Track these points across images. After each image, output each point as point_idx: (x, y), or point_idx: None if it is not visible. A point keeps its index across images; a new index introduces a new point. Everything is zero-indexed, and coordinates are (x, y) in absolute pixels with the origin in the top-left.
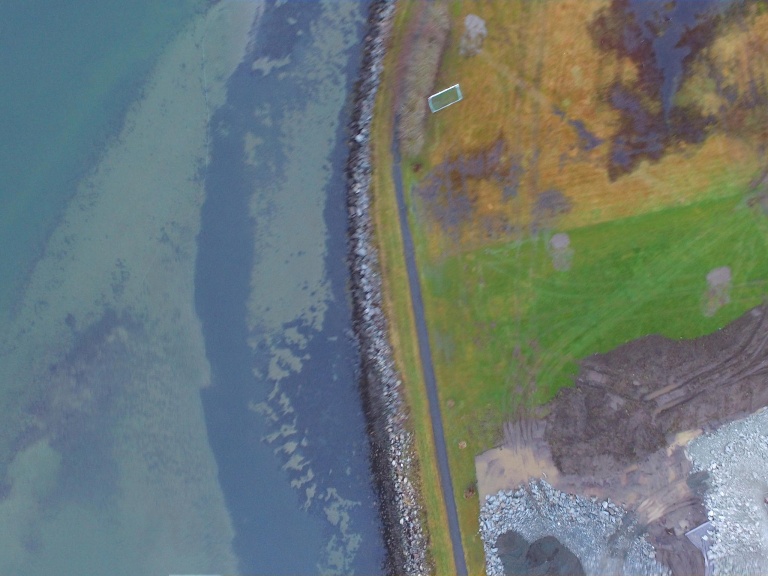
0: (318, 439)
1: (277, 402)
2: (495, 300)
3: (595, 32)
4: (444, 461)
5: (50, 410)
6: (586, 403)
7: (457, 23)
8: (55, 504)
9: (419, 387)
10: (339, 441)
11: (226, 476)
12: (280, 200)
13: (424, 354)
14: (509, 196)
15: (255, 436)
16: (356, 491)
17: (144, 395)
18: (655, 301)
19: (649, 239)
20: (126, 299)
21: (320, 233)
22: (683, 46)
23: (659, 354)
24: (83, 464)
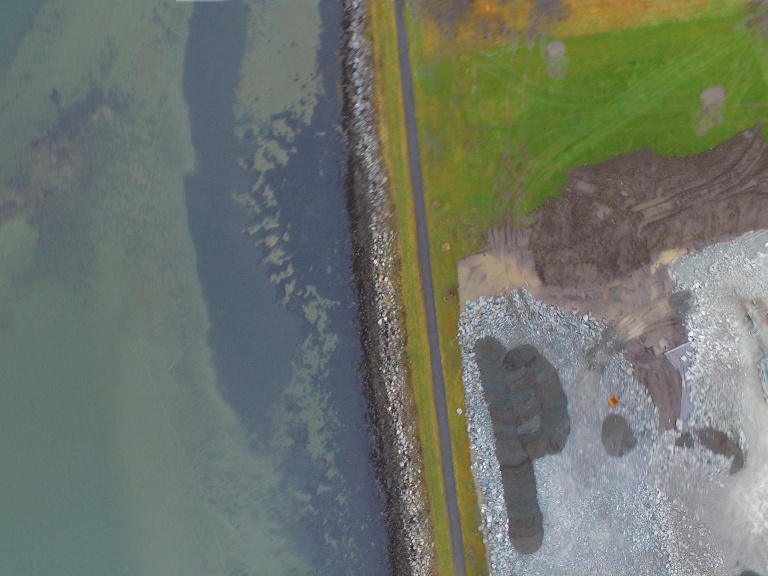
0: (300, 234)
1: (261, 194)
2: (487, 104)
3: None
4: (426, 263)
5: (29, 185)
6: (572, 212)
7: None
8: (28, 282)
9: (405, 186)
10: (321, 238)
11: (205, 266)
12: None
13: (412, 153)
14: None
15: (236, 227)
16: (336, 290)
17: (126, 177)
18: (648, 116)
19: (645, 53)
20: (113, 78)
21: (314, 25)
22: None
23: (649, 166)
24: (59, 243)
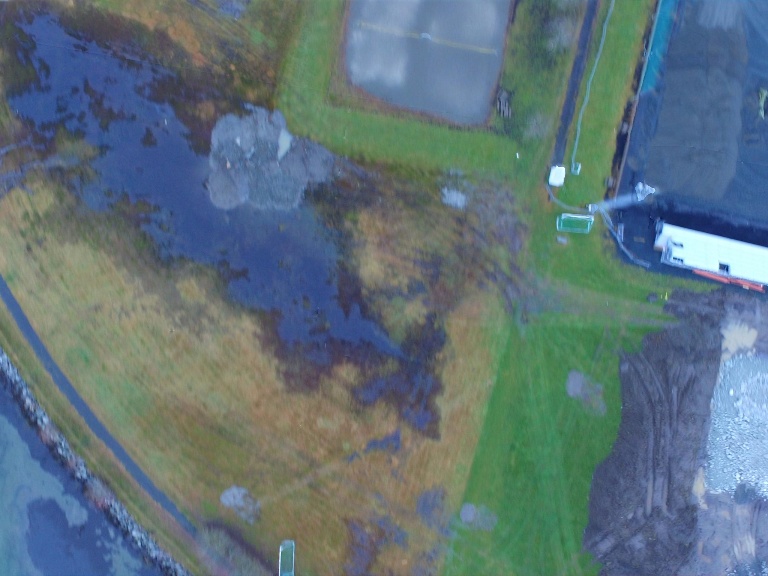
0: None
1: None
2: None
3: (295, 387)
4: None
5: None
6: (623, 565)
7: (223, 514)
8: None
9: None
10: None
11: None
12: None
13: None
14: (404, 541)
15: None
16: None
17: None
18: (566, 454)
19: (508, 432)
20: None
21: None
22: (349, 310)
23: (616, 483)
24: None
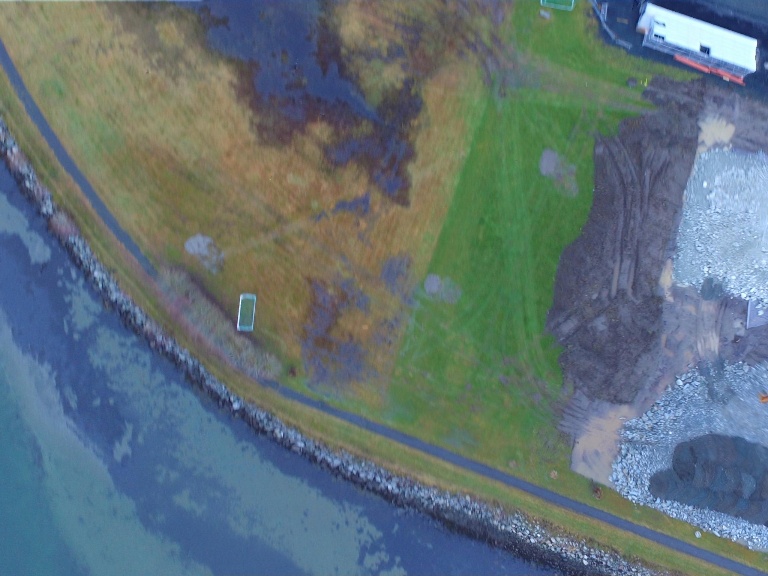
0: None
1: None
2: (449, 372)
3: (267, 140)
4: (558, 498)
5: None
6: (585, 348)
7: (186, 261)
8: None
9: (482, 483)
10: (486, 574)
11: None
12: (249, 505)
13: (457, 461)
14: (366, 305)
15: None
16: None
17: None
18: (535, 233)
19: (478, 205)
20: None
21: (298, 487)
22: (327, 68)
23: (583, 261)
24: None
